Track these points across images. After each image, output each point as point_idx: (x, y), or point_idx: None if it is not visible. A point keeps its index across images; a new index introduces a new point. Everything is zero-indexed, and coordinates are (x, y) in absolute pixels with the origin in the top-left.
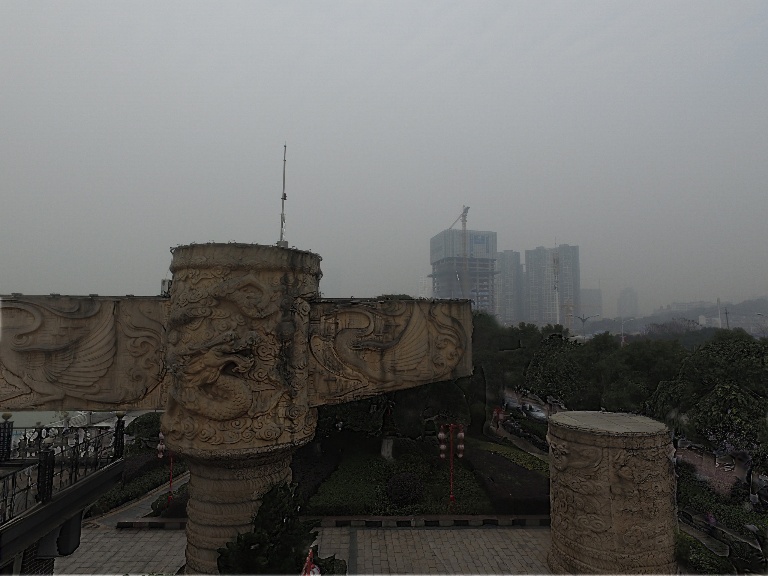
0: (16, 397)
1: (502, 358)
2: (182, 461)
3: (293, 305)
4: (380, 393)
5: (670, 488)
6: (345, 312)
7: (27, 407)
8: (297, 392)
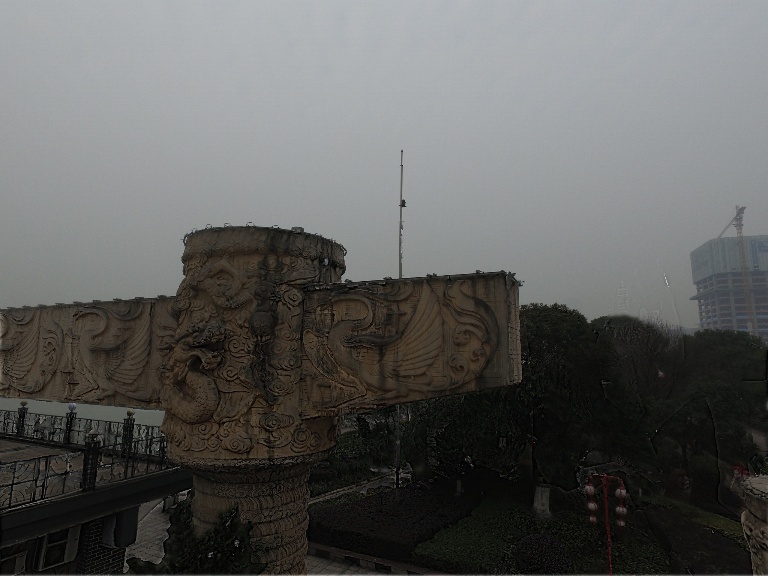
0: (90, 391)
1: (746, 392)
2: (330, 481)
3: (275, 293)
4: (380, 406)
5: None
6: (341, 300)
7: (94, 401)
8: (278, 398)
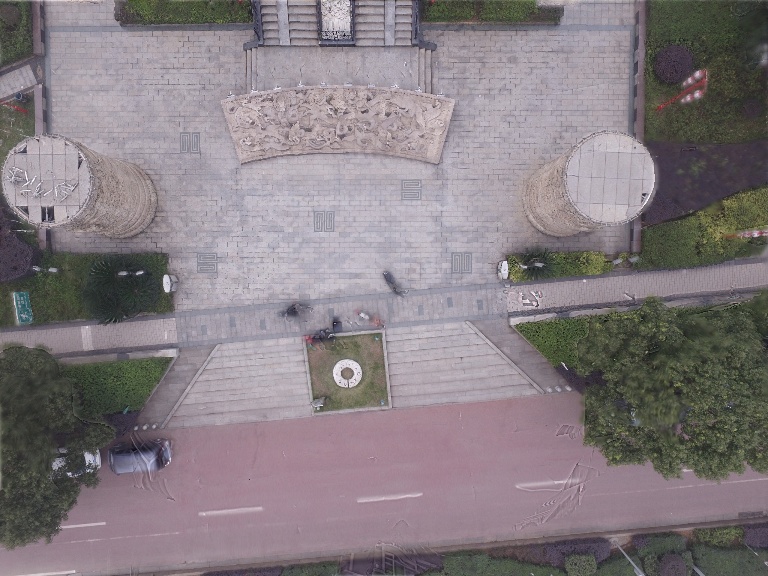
0: None
1: None
2: None
3: None
4: None
5: (553, 209)
6: None
7: None
8: None
